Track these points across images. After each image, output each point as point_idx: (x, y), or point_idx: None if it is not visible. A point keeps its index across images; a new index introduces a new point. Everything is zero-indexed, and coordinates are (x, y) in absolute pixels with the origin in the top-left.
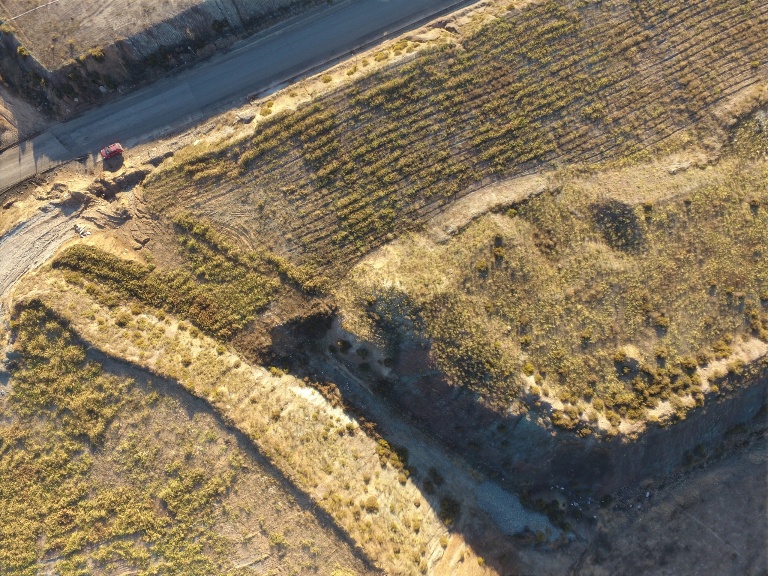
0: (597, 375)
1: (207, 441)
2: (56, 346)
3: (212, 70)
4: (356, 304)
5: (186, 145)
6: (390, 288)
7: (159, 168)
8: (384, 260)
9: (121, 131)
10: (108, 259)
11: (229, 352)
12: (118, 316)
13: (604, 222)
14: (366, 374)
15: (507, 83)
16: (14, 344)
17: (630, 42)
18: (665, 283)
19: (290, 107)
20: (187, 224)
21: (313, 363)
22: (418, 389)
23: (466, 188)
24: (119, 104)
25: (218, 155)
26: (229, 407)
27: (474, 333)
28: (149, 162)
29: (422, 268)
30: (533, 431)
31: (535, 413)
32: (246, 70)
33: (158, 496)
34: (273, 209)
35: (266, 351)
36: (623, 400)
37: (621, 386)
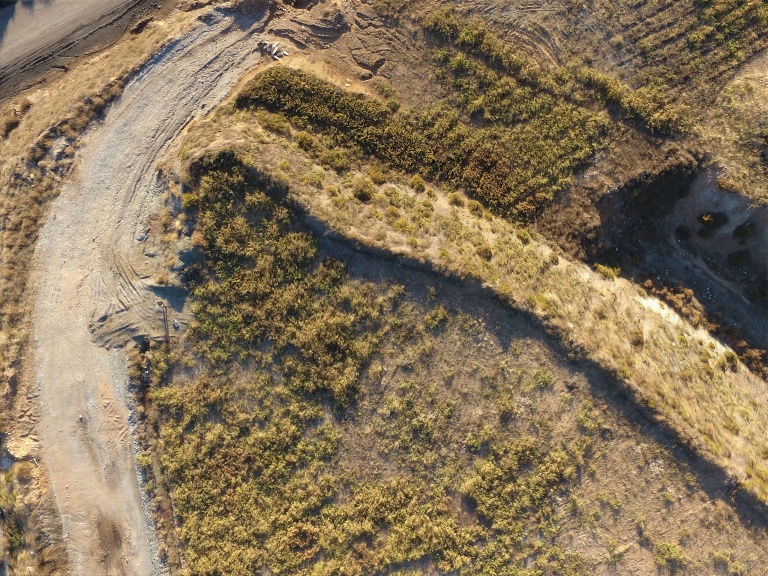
0: None
1: (537, 388)
2: (264, 236)
3: None
4: (742, 146)
5: None
6: None
7: None
8: None
9: None
10: (327, 91)
11: (534, 240)
12: (358, 183)
13: None
14: (739, 271)
15: None
16: (193, 235)
17: None
18: None
19: None
20: (449, 28)
21: (651, 258)
22: None
23: None
24: None
25: None
26: (571, 325)
27: None
28: None
29: None
30: None
31: None
32: None
33: (459, 489)
34: None
35: (593, 236)
36: None
37: None
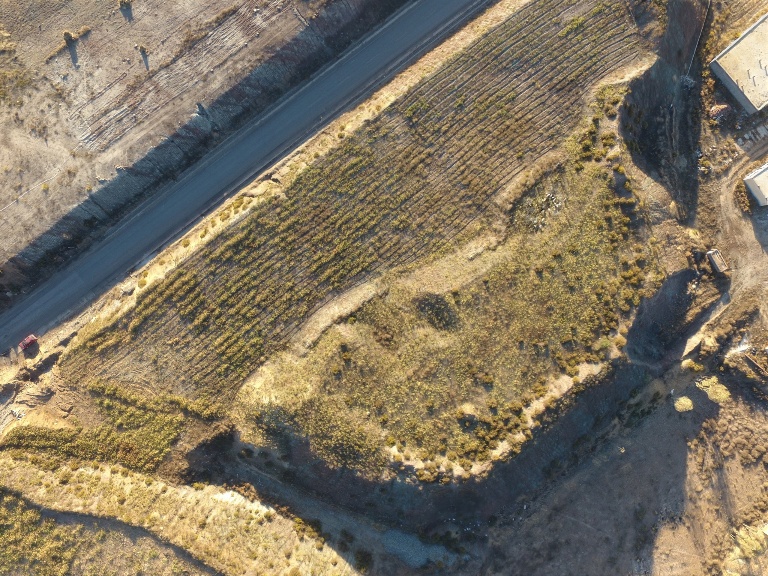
0: (446, 433)
1: (151, 558)
2: (16, 513)
3: (93, 257)
4: (247, 420)
5: (86, 323)
6: (268, 404)
7: (68, 348)
8: (261, 380)
9: (32, 324)
10: (43, 433)
11: (156, 481)
12: (60, 477)
13: (426, 310)
14: (272, 469)
15: (326, 217)
16: None
17: (417, 161)
18: (482, 349)
19: (160, 276)
20: (99, 389)
21: (228, 470)
22: (312, 474)
23: (314, 306)
24: (25, 302)
25: (111, 328)
26: (162, 528)
27: (340, 425)
28: (59, 344)
29: (291, 381)
30: (406, 488)
31: (402, 475)
32: (120, 251)
33: None
34: (165, 360)
35: (186, 473)
36: (470, 448)
37: (467, 437)
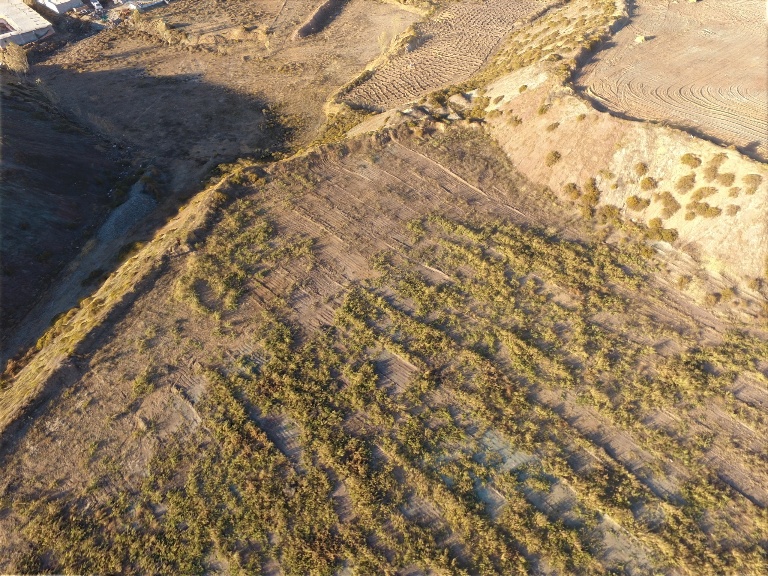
0: None
1: None
2: None
3: None
4: None
5: None
6: None
7: None
8: None
9: None
10: None
11: None
12: None
13: None
14: None
15: None
16: None
17: None
18: None
19: None
20: None
21: None
22: None
23: None
24: None
25: None
26: None
27: None
28: None
29: None
30: None
31: None
32: None
33: None
34: None
35: None
36: None
37: None
